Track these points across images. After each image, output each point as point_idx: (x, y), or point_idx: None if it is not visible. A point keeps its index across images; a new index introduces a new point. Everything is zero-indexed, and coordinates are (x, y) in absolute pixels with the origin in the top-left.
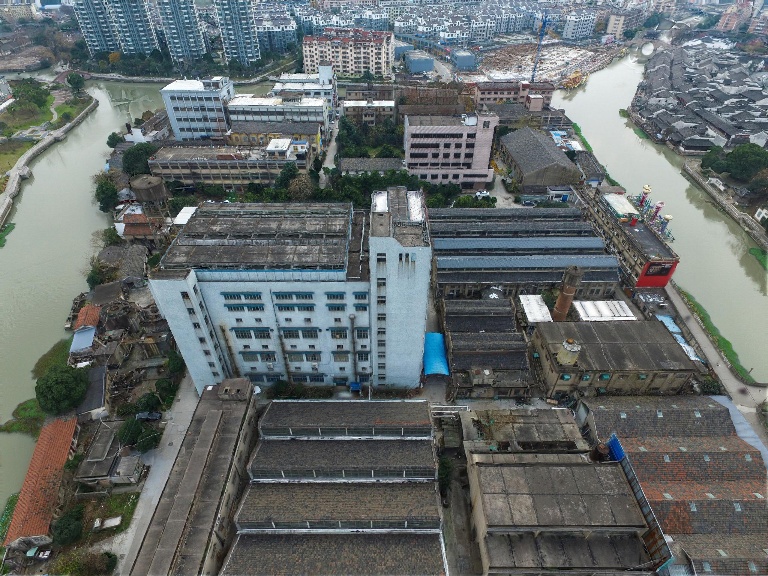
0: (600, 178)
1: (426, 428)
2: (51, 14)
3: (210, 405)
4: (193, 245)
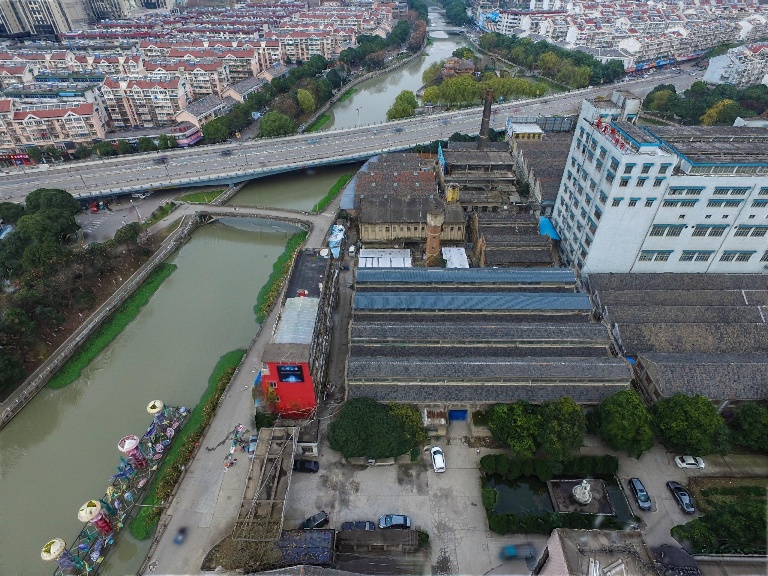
0: None
1: None
2: None
3: None
4: None
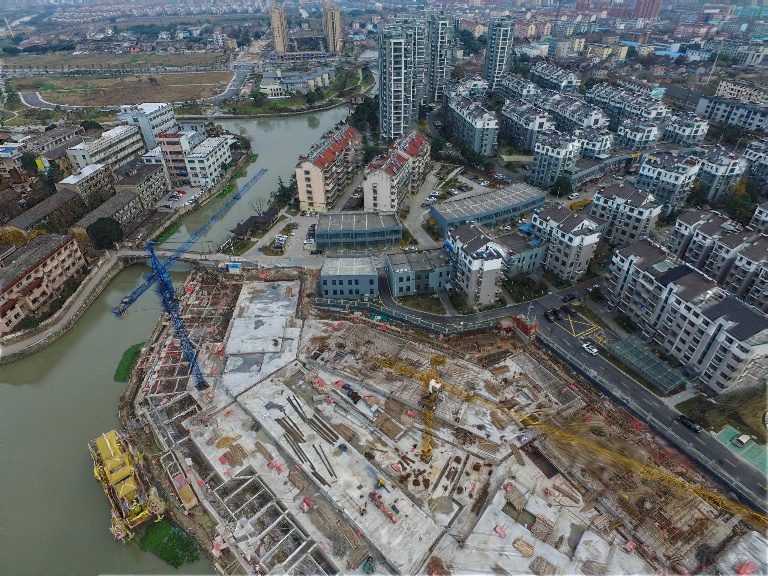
0: None
1: None
2: (598, 58)
3: None
4: None
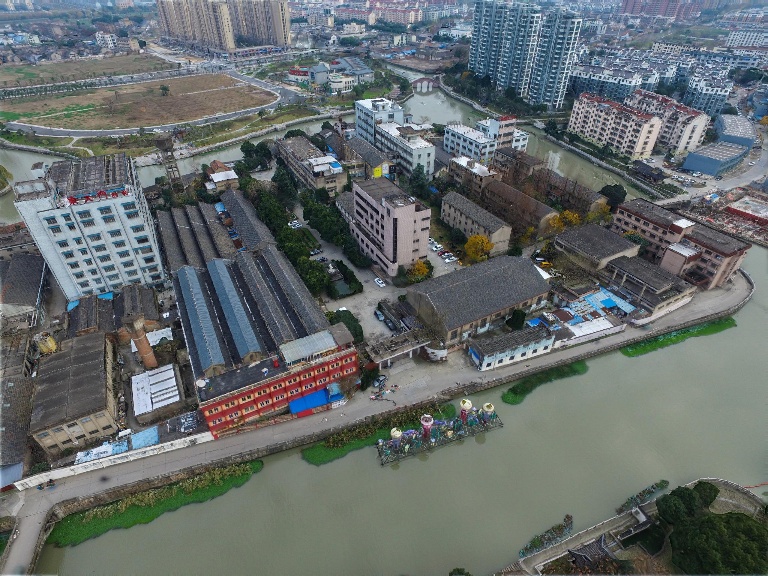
0: (481, 357)
1: None
2: None
3: None
4: None
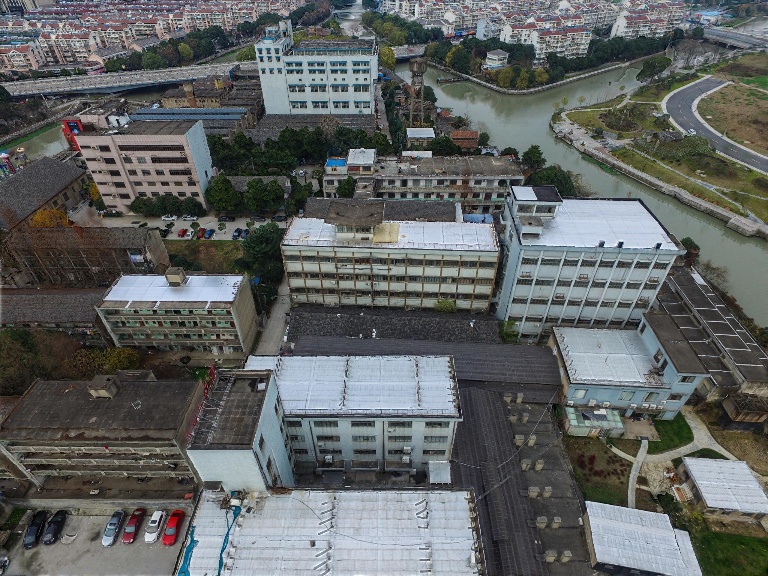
0: None
1: None
2: None
3: None
4: (365, 41)
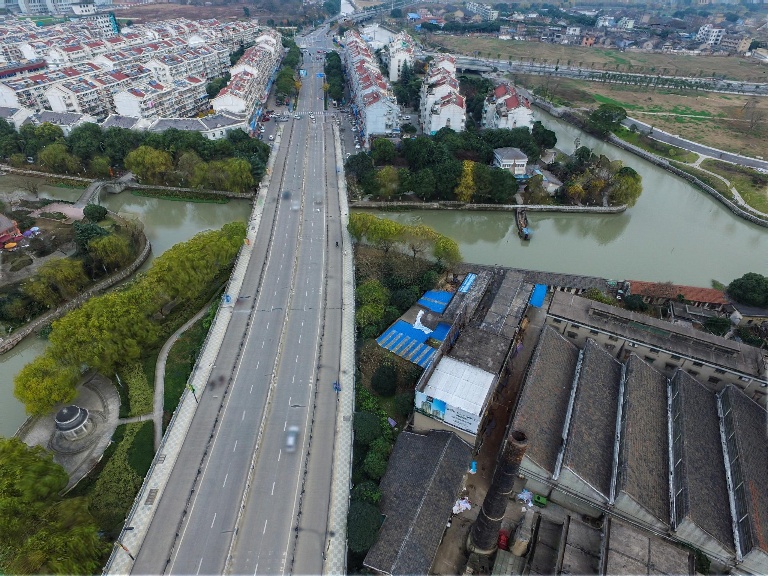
0: None
1: (752, 543)
2: None
3: (748, 351)
4: None
